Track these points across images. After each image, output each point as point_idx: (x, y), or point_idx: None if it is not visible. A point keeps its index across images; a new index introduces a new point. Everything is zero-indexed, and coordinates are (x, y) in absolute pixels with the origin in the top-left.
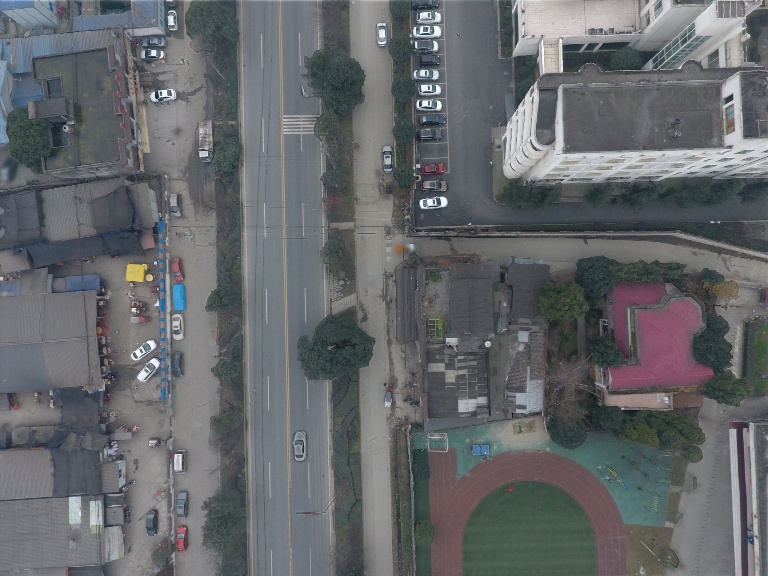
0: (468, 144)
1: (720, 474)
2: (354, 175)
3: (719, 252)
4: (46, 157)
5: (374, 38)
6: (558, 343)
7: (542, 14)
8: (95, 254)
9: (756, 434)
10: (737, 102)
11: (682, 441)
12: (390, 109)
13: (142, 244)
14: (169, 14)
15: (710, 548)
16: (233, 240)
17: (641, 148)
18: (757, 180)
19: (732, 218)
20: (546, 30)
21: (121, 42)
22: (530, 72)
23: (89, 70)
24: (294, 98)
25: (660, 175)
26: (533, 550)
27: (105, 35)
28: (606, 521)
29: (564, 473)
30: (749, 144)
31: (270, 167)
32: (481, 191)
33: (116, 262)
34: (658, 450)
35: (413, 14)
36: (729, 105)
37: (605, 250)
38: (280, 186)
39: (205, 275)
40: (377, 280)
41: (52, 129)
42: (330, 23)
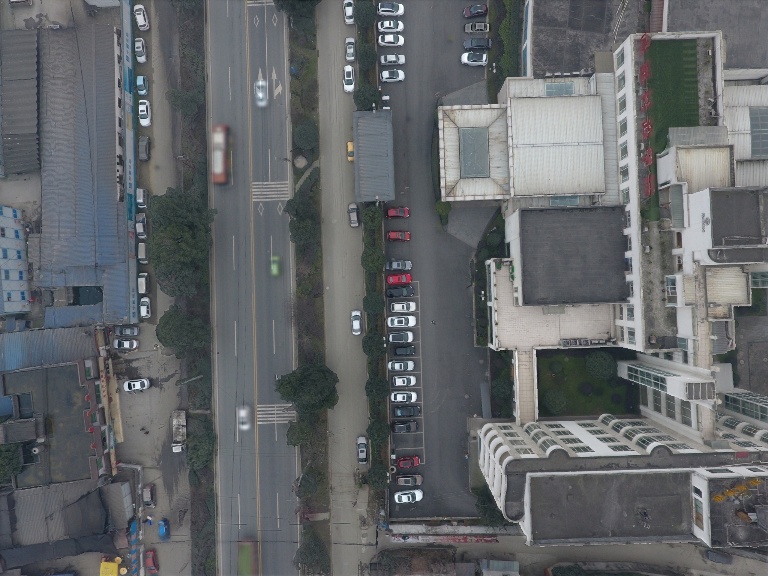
0: (443, 434)
1: None
2: (329, 464)
3: None
4: (17, 474)
5: (349, 325)
6: None
7: (516, 321)
8: (68, 555)
9: None
10: (705, 506)
11: None
12: (365, 397)
13: (115, 544)
14: (142, 303)
15: None
16: (207, 533)
17: (610, 533)
18: None
19: None
20: (520, 338)
21: (93, 342)
22: (505, 365)
23: (59, 385)
24: (268, 387)
25: None
26: None
27: (77, 332)
28: None
29: None
30: None
31: (244, 457)
32: (457, 482)
33: (90, 553)
34: None
35: (388, 301)
36: (698, 499)
37: None
38: (254, 477)
39: (180, 565)
40: (352, 571)
41: (22, 446)
42: (304, 313)
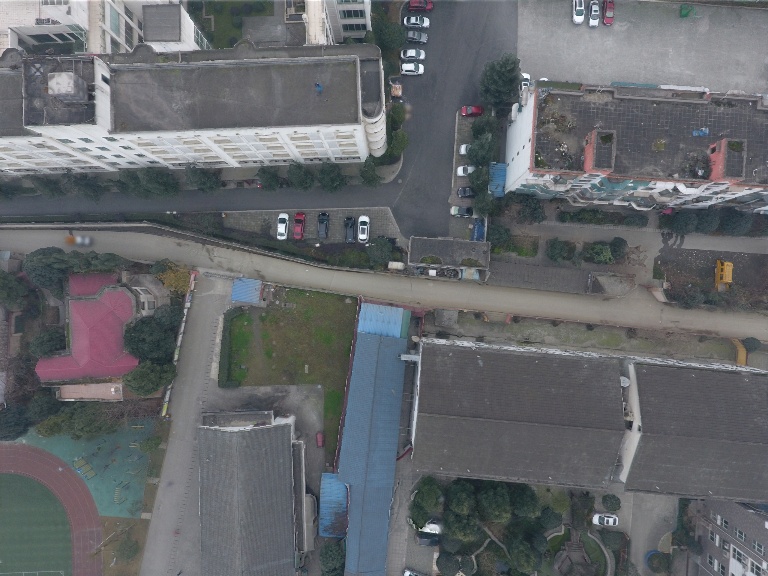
0: None
1: (198, 465)
2: None
3: (203, 243)
4: None
5: None
6: (37, 335)
7: None
8: None
9: (202, 424)
10: None
11: (66, 431)
12: None
13: None
14: None
15: (187, 539)
16: None
17: None
18: (215, 170)
19: (215, 209)
20: None
21: None
22: None
23: None
24: None
25: (91, 165)
26: (9, 542)
27: None
28: (82, 513)
29: (41, 465)
30: (56, 132)
31: None
32: None
33: None
34: (129, 441)
35: None
36: None
37: (90, 241)
38: None
39: None
40: None
41: None
42: None
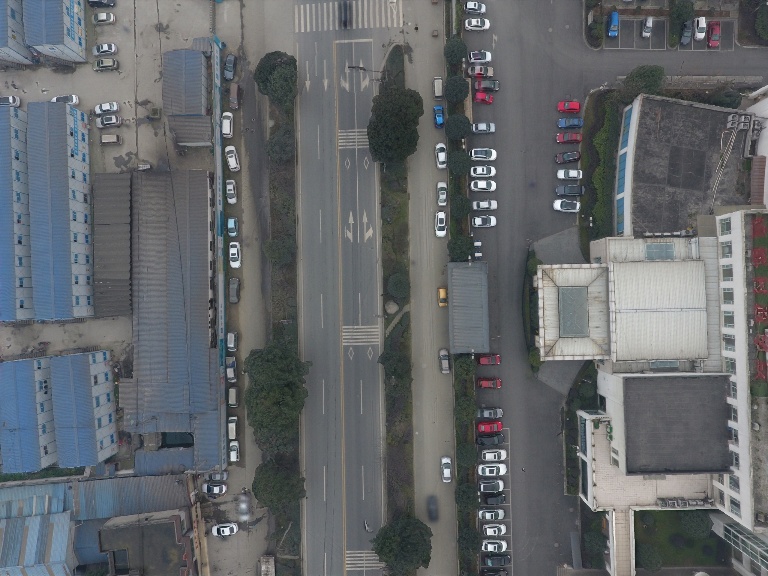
0: None
1: None
2: None
3: None
4: None
5: (438, 470)
6: None
7: (613, 480)
8: None
9: None
10: None
11: None
12: (454, 544)
13: None
14: (231, 448)
15: None
16: None
17: None
18: None
19: None
20: (617, 497)
21: (185, 492)
22: (597, 516)
23: (155, 542)
24: (357, 533)
25: None
26: None
27: (168, 480)
28: None
29: None
30: None
31: None
32: None
33: None
34: None
35: (478, 448)
36: None
37: None
38: None
39: None
40: None
41: None
42: (394, 460)
